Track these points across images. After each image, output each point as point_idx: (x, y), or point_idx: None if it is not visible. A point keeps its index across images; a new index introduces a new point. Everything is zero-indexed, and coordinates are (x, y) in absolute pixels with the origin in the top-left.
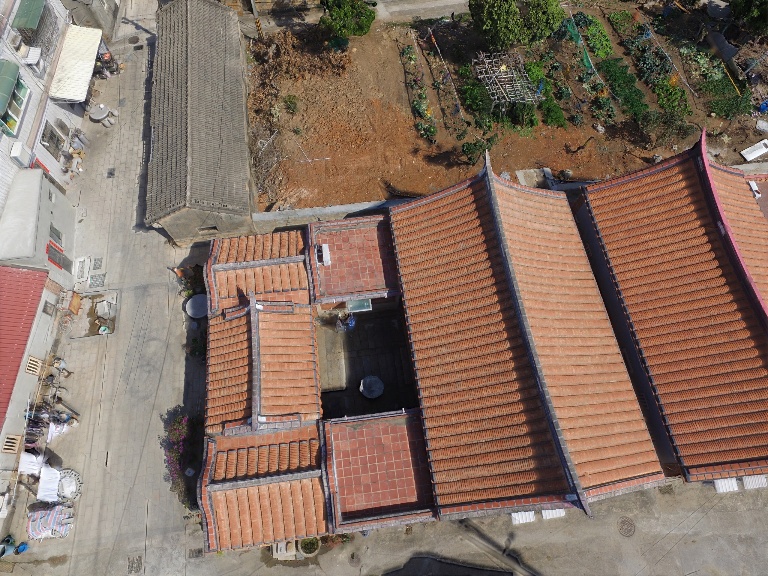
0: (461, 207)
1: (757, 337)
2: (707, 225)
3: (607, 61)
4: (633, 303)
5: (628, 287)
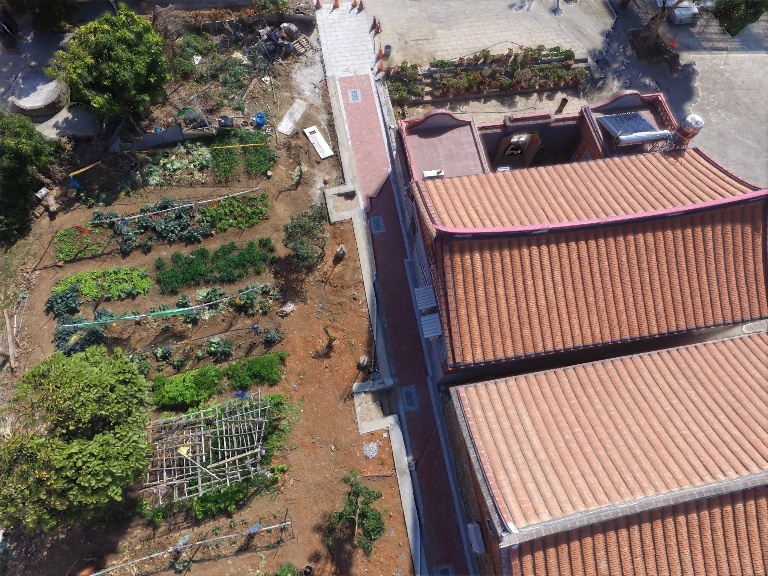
0: (547, 569)
1: (654, 228)
2: (529, 243)
3: (163, 280)
4: (609, 332)
5: (591, 334)
